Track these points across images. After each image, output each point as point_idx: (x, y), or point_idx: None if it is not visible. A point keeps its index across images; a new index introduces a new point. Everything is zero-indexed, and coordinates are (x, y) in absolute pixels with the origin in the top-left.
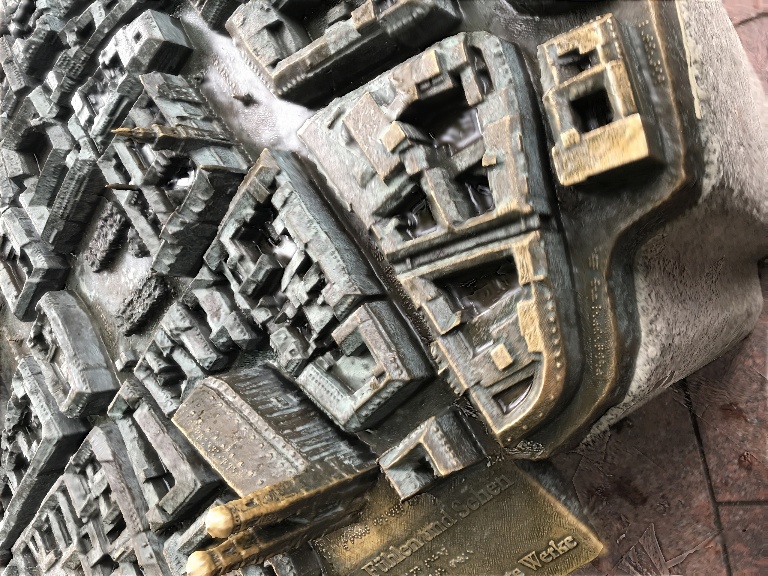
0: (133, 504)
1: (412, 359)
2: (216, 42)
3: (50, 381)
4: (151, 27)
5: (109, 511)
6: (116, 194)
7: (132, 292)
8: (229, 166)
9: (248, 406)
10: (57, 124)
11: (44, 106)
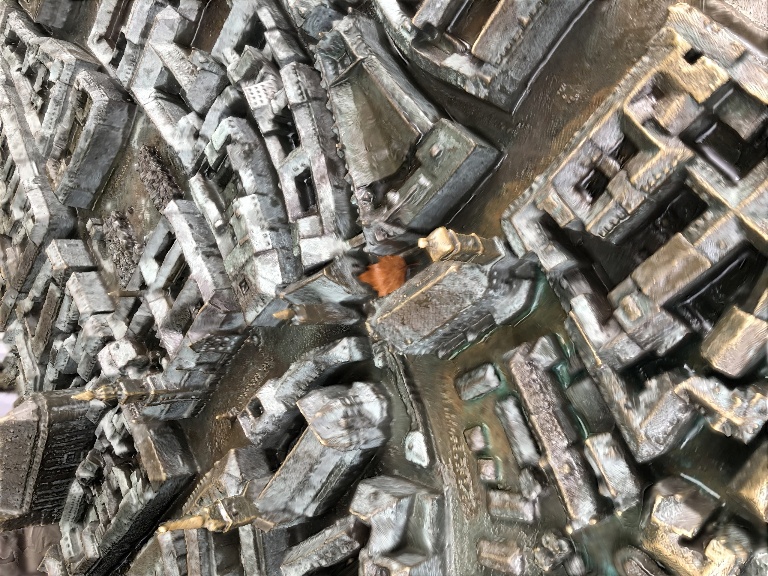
0: (26, 276)
1: (96, 575)
2: (280, 369)
3: (62, 132)
4: (255, 307)
5: (18, 248)
6: (145, 251)
7: (122, 243)
8: (169, 415)
9: (40, 460)
10: (218, 73)
11: (231, 38)
